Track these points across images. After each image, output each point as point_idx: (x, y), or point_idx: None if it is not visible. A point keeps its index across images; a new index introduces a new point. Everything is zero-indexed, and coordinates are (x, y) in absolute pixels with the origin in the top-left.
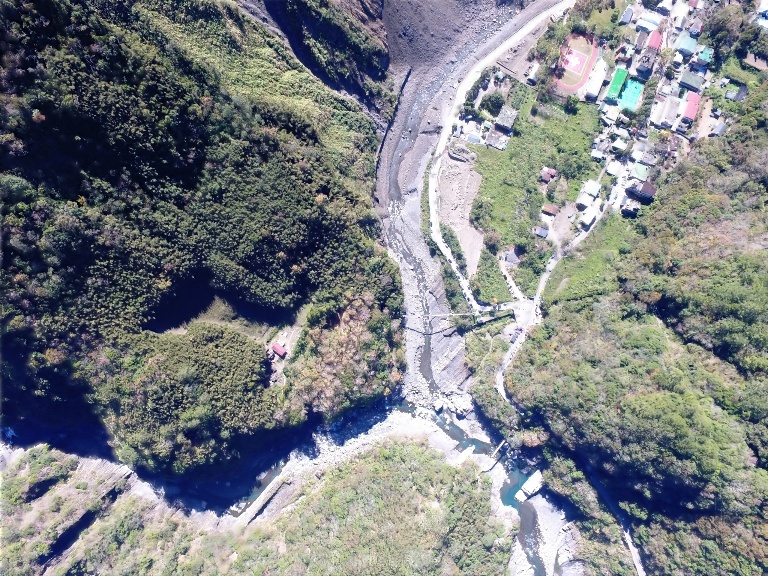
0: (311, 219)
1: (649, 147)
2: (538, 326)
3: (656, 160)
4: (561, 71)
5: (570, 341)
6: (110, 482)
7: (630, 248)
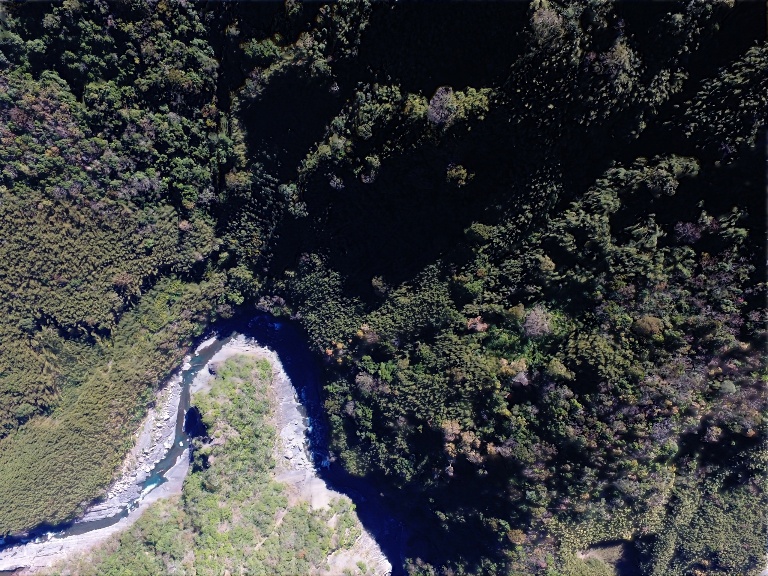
0: None
1: None
2: None
3: None
4: None
5: None
6: (378, 575)
7: None
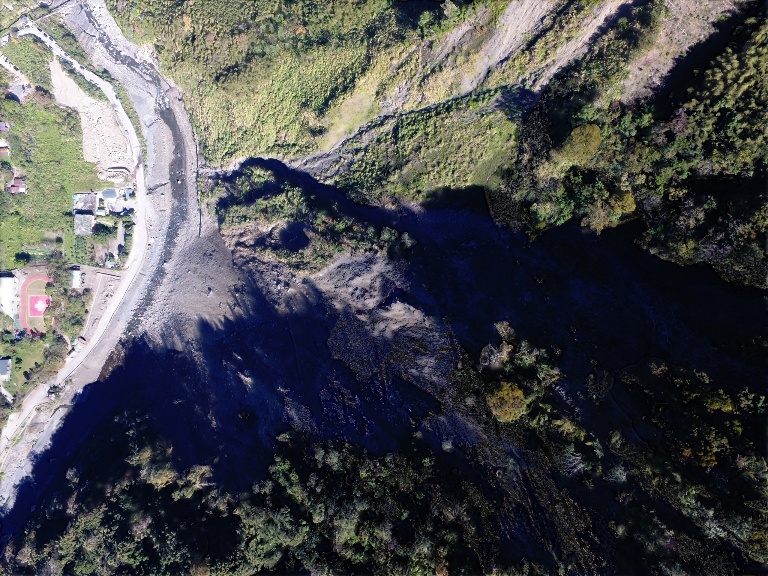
0: None
1: None
2: None
3: None
4: None
5: None
6: None
7: None
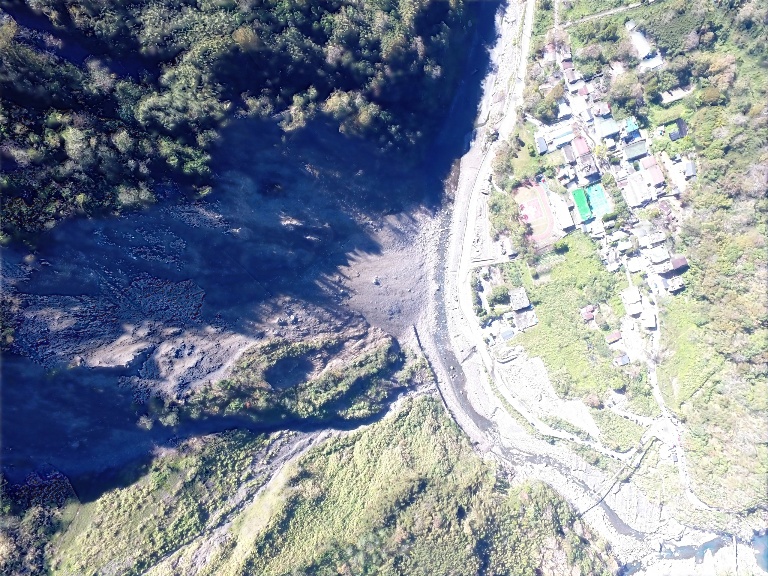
0: (474, 548)
1: (647, 226)
2: (688, 438)
3: (663, 234)
4: (528, 228)
5: (731, 440)
6: None
7: (705, 319)
